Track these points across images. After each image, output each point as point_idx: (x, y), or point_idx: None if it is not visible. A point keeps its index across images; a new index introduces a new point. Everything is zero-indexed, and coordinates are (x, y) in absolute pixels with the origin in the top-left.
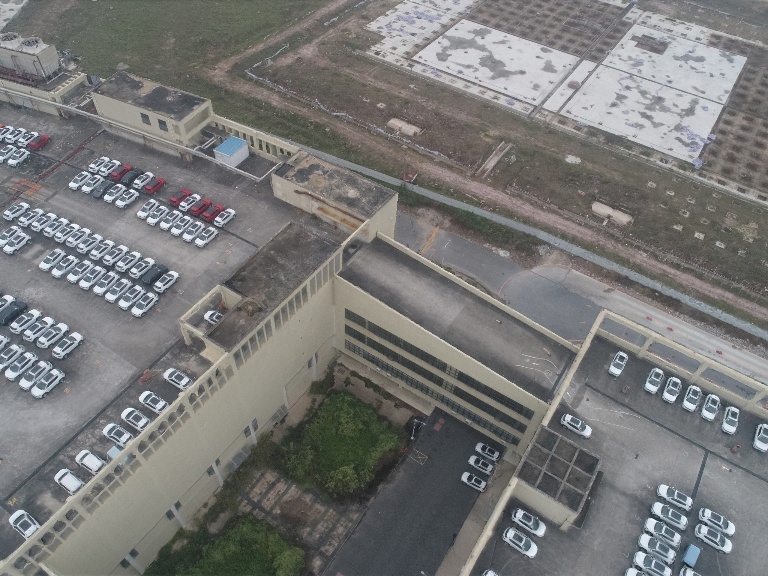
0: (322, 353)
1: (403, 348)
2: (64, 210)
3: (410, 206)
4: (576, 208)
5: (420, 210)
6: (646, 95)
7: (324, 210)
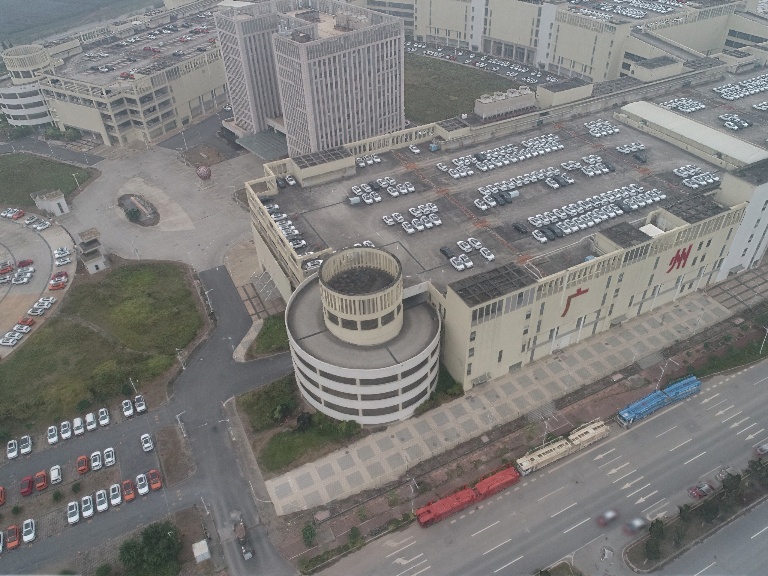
0: None
1: (750, 40)
2: None
3: None
4: None
5: None
6: None
7: None
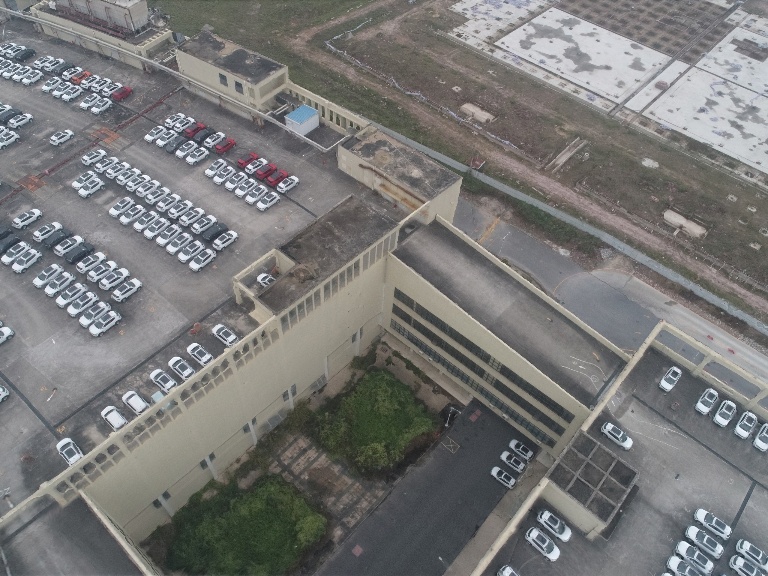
0: (367, 329)
1: (448, 334)
2: (138, 161)
3: (473, 193)
4: (647, 214)
5: (483, 199)
6: (739, 103)
7: (386, 187)
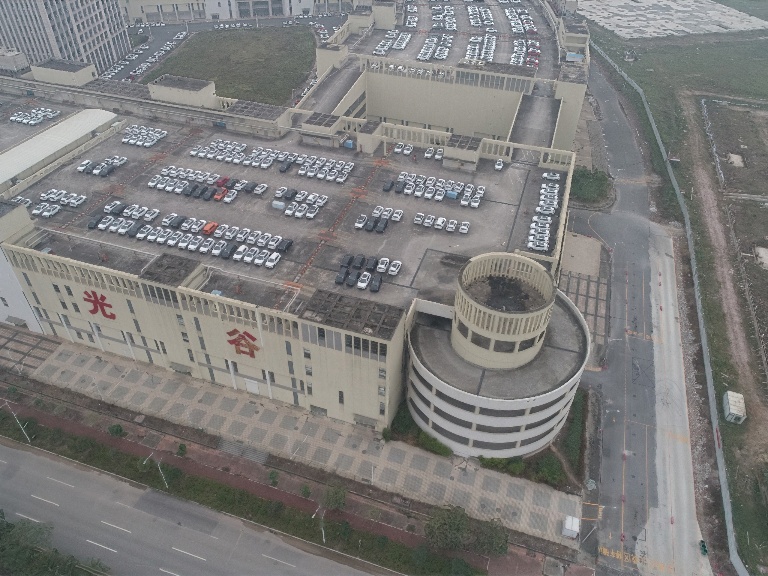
0: None
1: None
2: None
3: (654, 171)
4: (744, 237)
5: (655, 175)
6: None
7: None
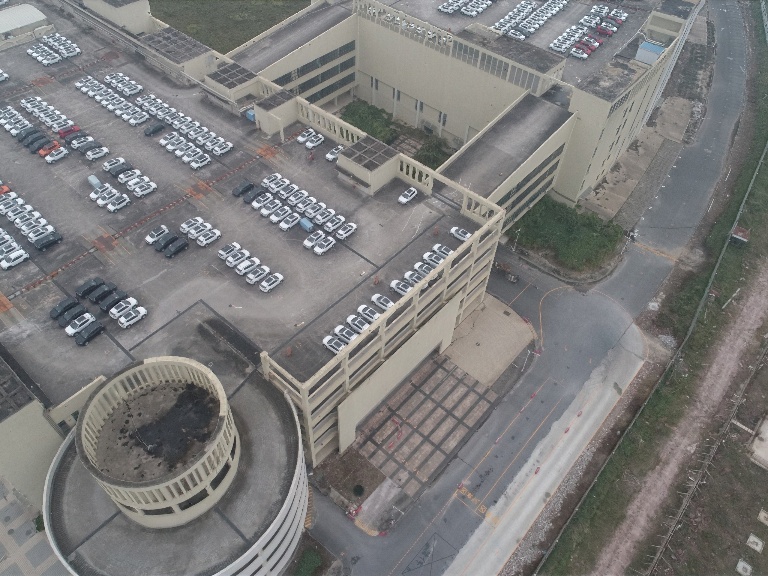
0: None
1: None
2: (573, 8)
3: (703, 244)
4: (760, 397)
5: (700, 251)
6: None
7: None
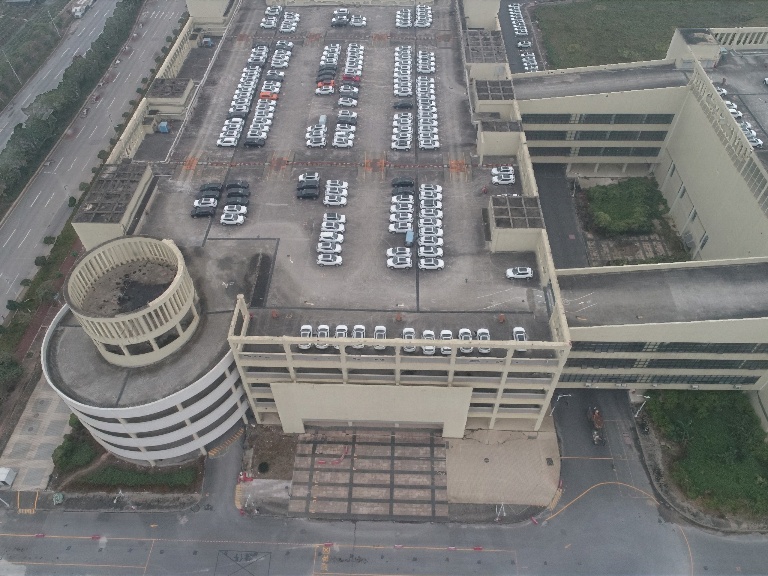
0: None
1: None
2: None
3: None
4: None
5: None
6: None
7: None
